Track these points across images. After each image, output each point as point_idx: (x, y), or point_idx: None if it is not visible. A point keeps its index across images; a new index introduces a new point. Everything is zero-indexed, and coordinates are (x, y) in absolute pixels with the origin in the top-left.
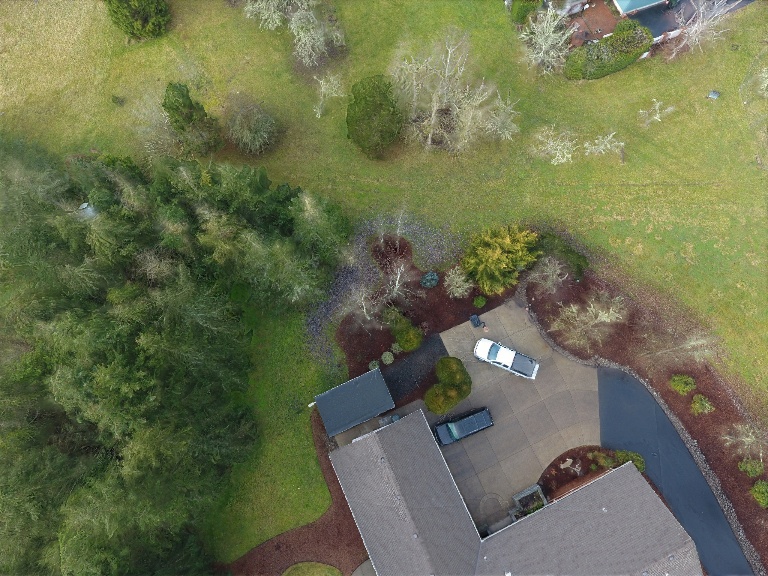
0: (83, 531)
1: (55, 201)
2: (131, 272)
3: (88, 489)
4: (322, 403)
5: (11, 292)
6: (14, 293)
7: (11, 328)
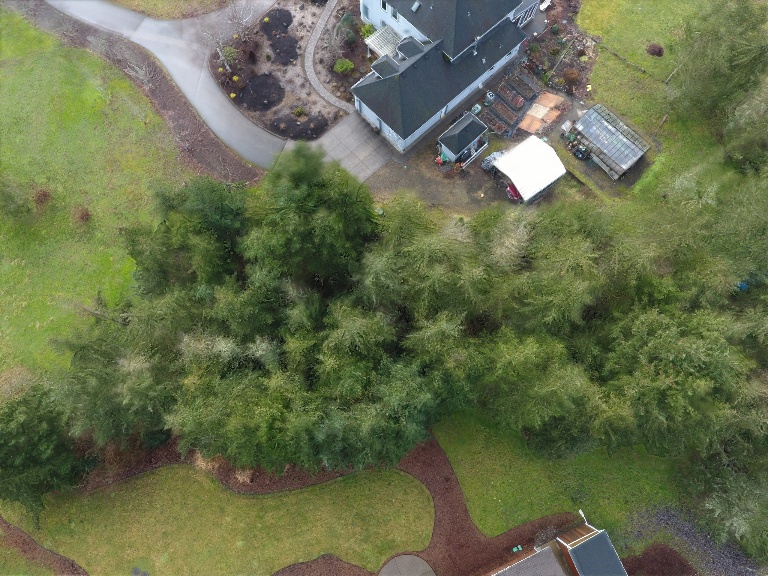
0: (537, 363)
1: (763, 242)
2: (764, 368)
3: (573, 363)
4: (601, 540)
5: (654, 206)
6: (654, 209)
7: (696, 266)
